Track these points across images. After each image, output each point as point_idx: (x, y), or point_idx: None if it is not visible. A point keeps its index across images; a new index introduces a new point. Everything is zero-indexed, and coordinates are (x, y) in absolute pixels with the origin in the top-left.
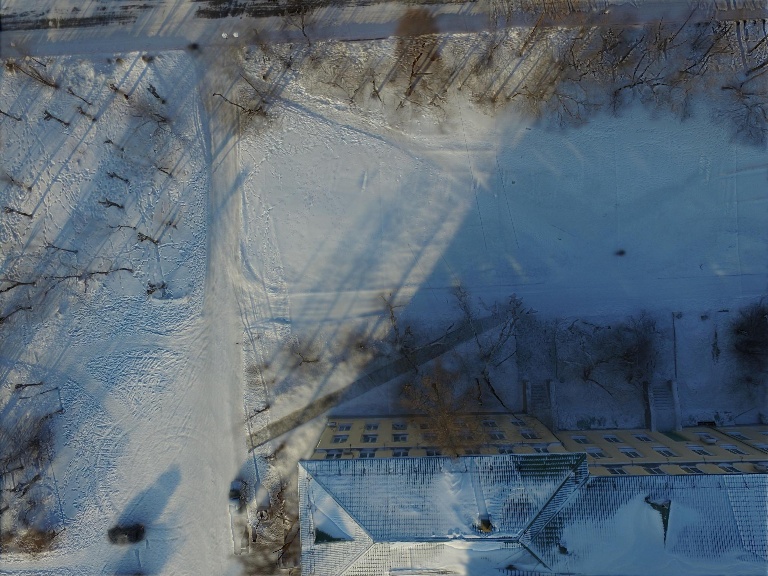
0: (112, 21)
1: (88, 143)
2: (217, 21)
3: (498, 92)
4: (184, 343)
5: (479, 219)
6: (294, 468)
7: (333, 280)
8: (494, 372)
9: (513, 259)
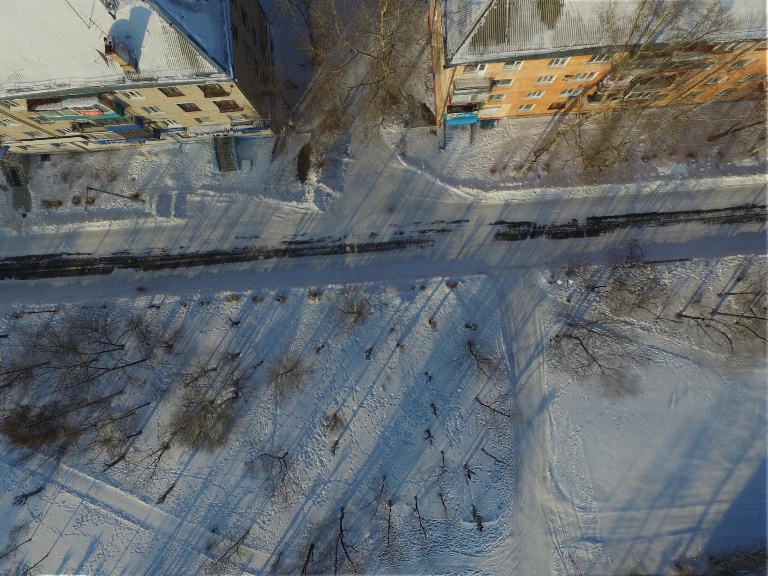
0: (410, 245)
1: (391, 368)
2: (516, 243)
3: None
4: (494, 563)
5: None
6: None
7: (643, 499)
8: None
9: None
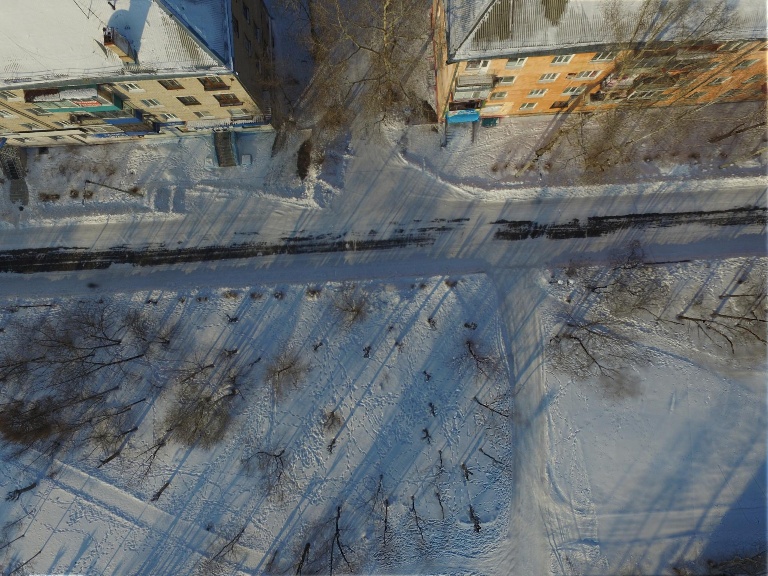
0: (410, 243)
1: (390, 366)
2: (517, 243)
3: None
4: (491, 565)
5: None
6: None
7: (642, 501)
8: None
9: None
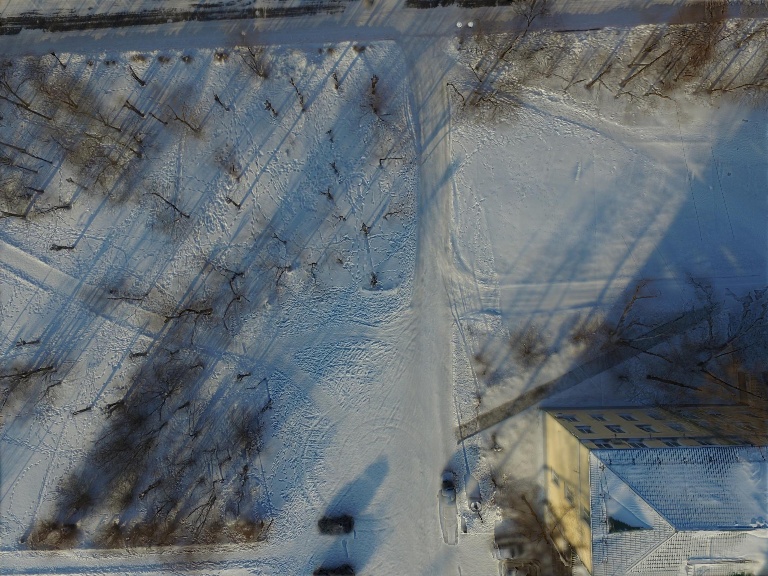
0: (320, 11)
1: (296, 133)
2: (427, 11)
3: (714, 83)
4: (392, 334)
5: (695, 211)
6: (505, 459)
7: (545, 272)
8: (710, 364)
9: (729, 251)
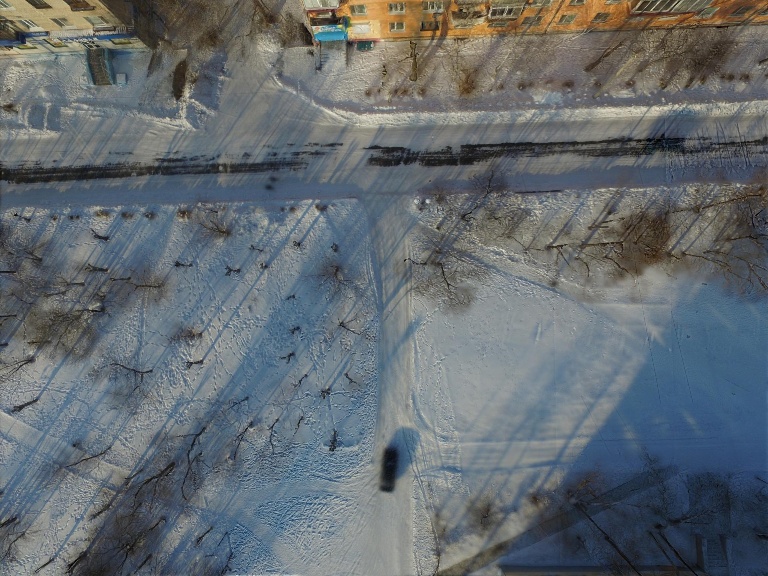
0: (283, 167)
1: (259, 289)
2: (389, 169)
3: (674, 246)
4: (354, 489)
5: (654, 373)
6: None
7: (505, 430)
8: None
9: (687, 413)
